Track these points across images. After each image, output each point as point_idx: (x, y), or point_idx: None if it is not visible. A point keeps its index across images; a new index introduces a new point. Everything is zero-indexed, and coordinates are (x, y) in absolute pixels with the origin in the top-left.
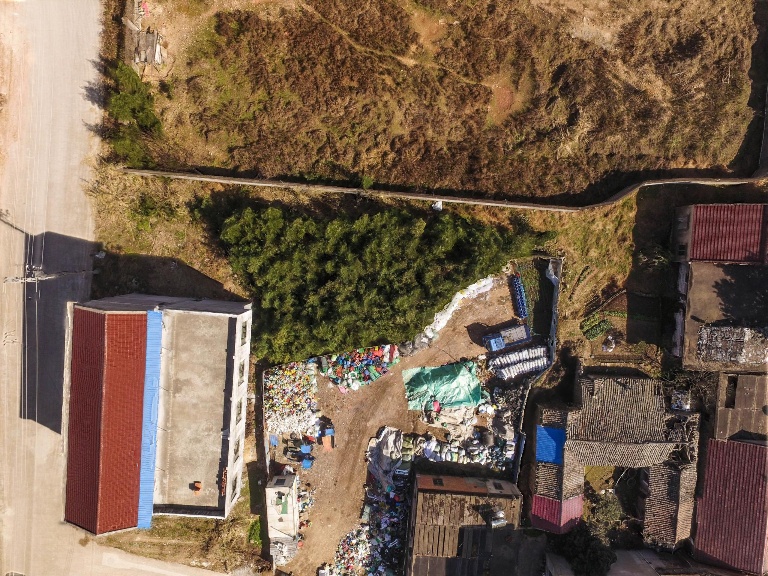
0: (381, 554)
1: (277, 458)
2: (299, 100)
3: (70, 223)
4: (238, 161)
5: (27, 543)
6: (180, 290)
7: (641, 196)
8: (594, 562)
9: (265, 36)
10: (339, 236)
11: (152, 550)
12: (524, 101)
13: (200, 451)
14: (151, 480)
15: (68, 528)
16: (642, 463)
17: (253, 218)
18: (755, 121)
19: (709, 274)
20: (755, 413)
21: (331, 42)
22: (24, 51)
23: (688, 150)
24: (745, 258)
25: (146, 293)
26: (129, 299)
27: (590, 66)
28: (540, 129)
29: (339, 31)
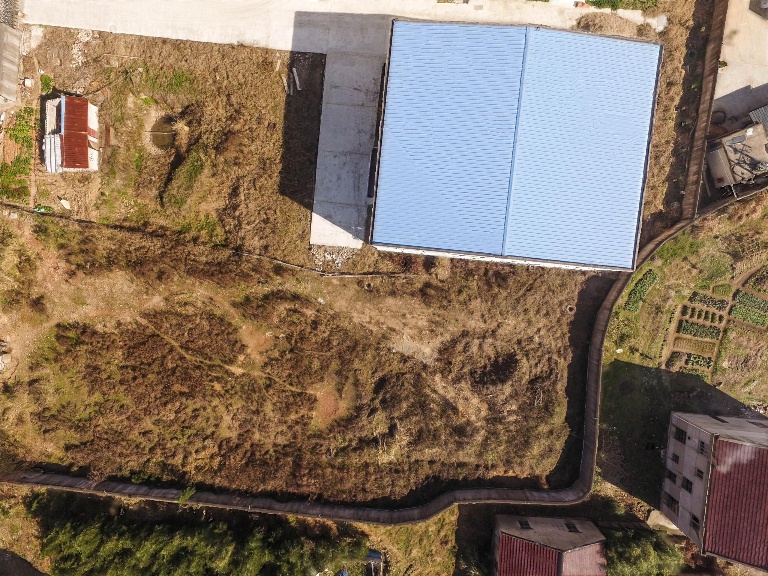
0: None
1: None
2: (132, 404)
3: None
4: (73, 459)
5: None
6: None
7: None
8: None
9: (100, 347)
10: (156, 549)
11: None
12: (348, 408)
13: None
14: None
15: None
16: None
17: (69, 537)
18: None
19: None
20: None
21: (162, 353)
22: None
23: (506, 463)
24: None
25: None
26: None
27: (410, 380)
28: (362, 436)
29: (171, 342)
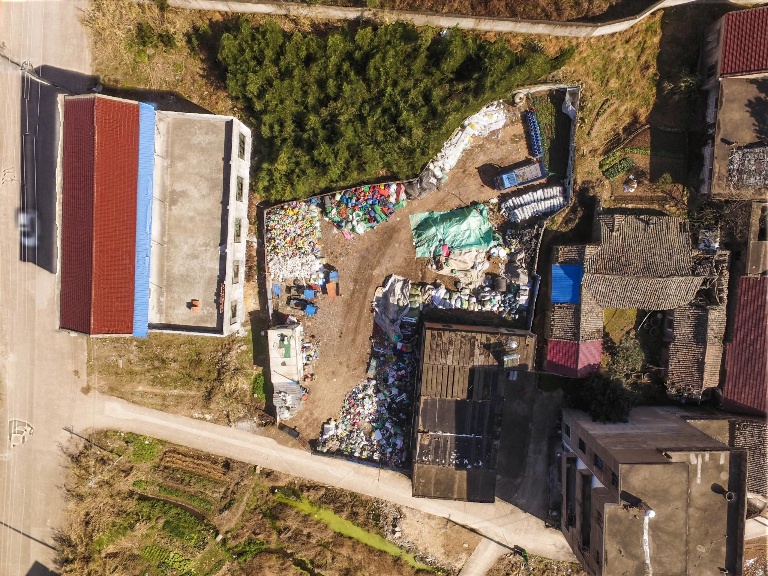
0: (388, 410)
1: (280, 308)
2: None
3: (66, 55)
4: None
5: (29, 390)
6: None
7: (666, 19)
8: (614, 403)
9: None
10: (341, 56)
11: (154, 400)
12: None
13: (197, 267)
14: (146, 286)
15: (70, 376)
16: (666, 304)
17: (251, 33)
18: None
19: (741, 91)
20: None
21: None
22: None
23: None
24: None
25: None
26: None
27: None
28: None
29: None
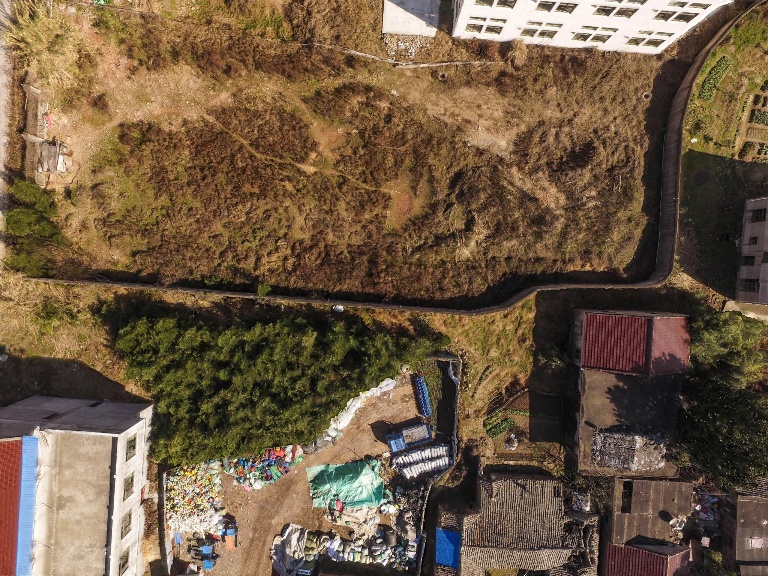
0: None
1: (181, 556)
2: (201, 206)
3: None
4: (141, 265)
5: None
6: (82, 392)
7: (540, 298)
8: None
9: (167, 145)
10: (234, 343)
11: None
12: (423, 206)
13: (84, 567)
14: None
15: None
16: (542, 566)
17: (147, 328)
18: (650, 225)
19: (602, 380)
20: (651, 518)
21: (232, 151)
22: None
23: (584, 254)
24: (632, 369)
25: (48, 395)
26: (21, 410)
27: (486, 173)
28: (438, 233)
29: (240, 140)
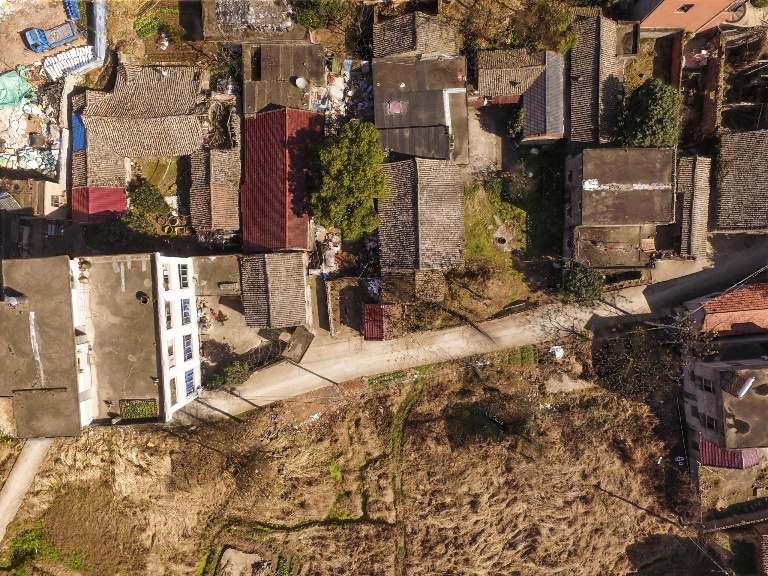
0: None
1: None
2: None
3: None
4: None
5: None
6: None
7: None
8: None
9: None
10: None
11: None
12: None
13: None
14: None
15: None
16: (180, 150)
17: None
18: None
19: None
20: (282, 84)
21: None
22: None
23: None
24: None
25: None
26: None
27: None
28: None
29: None
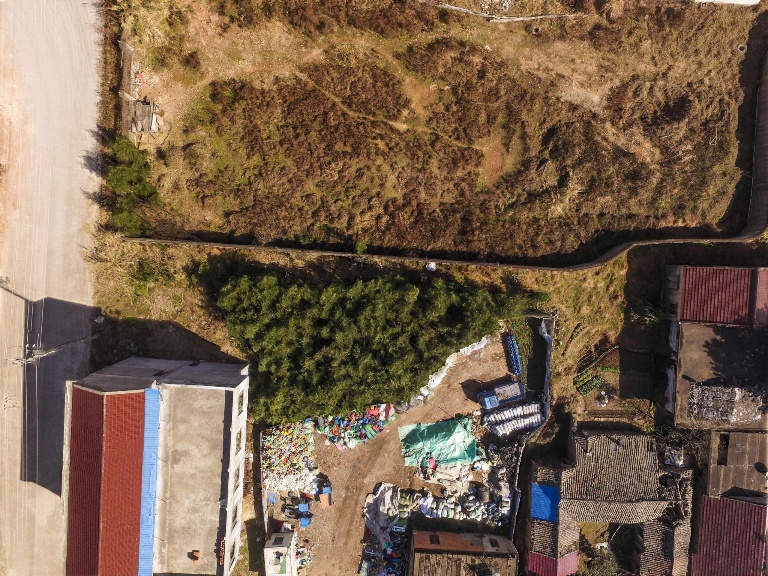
0: None
1: (275, 515)
2: (293, 165)
3: (69, 289)
4: (234, 226)
5: None
6: (178, 353)
7: (632, 254)
8: None
9: (259, 104)
10: (334, 301)
11: None
12: (515, 163)
13: (198, 520)
14: (150, 554)
15: None
16: (636, 519)
17: (249, 286)
18: (743, 180)
19: (699, 334)
20: (747, 470)
21: (324, 109)
22: (23, 122)
23: (677, 210)
24: (734, 321)
25: (144, 356)
26: (127, 368)
27: (579, 129)
28: (531, 190)
29: (332, 98)
